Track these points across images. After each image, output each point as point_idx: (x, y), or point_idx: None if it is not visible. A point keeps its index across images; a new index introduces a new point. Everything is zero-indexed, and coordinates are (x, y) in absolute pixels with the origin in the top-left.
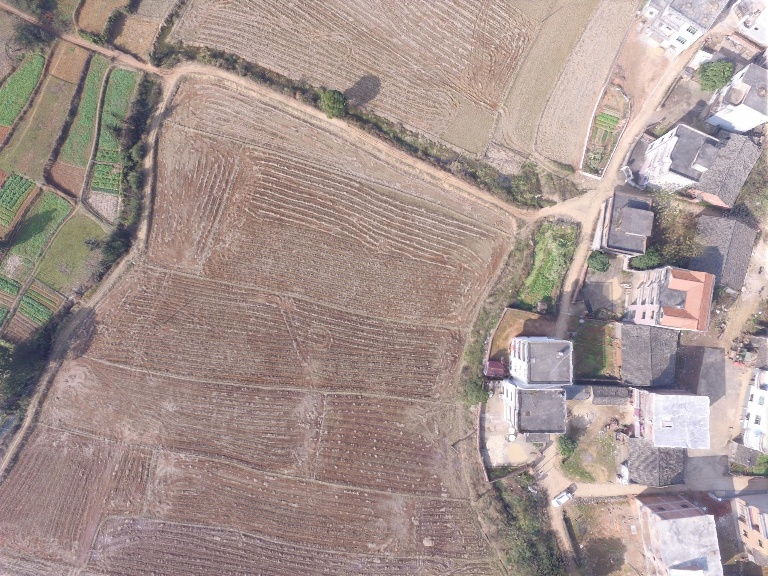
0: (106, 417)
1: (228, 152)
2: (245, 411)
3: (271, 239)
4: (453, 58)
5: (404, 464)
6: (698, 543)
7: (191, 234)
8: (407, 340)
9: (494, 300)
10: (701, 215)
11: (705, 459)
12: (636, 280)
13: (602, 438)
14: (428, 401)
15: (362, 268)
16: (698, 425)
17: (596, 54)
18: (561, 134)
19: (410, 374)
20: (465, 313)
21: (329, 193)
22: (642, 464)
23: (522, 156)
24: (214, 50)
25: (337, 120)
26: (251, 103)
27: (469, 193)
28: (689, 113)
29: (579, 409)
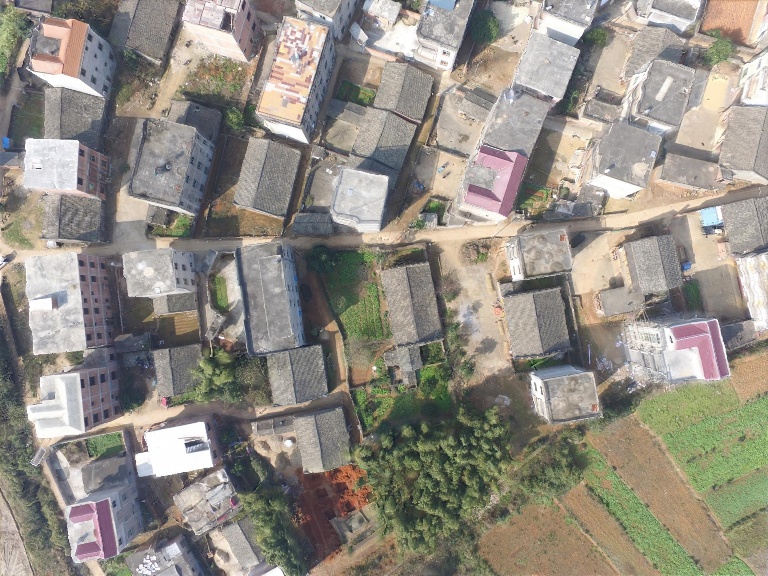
0: None
1: None
2: None
3: None
4: None
5: None
6: (60, 278)
7: None
8: None
9: None
10: None
11: (132, 224)
12: None
13: (41, 206)
14: None
15: None
16: (66, 167)
17: None
18: None
19: None
20: None
21: None
22: (50, 219)
23: None
24: None
25: None
26: None
27: None
28: None
29: (21, 179)
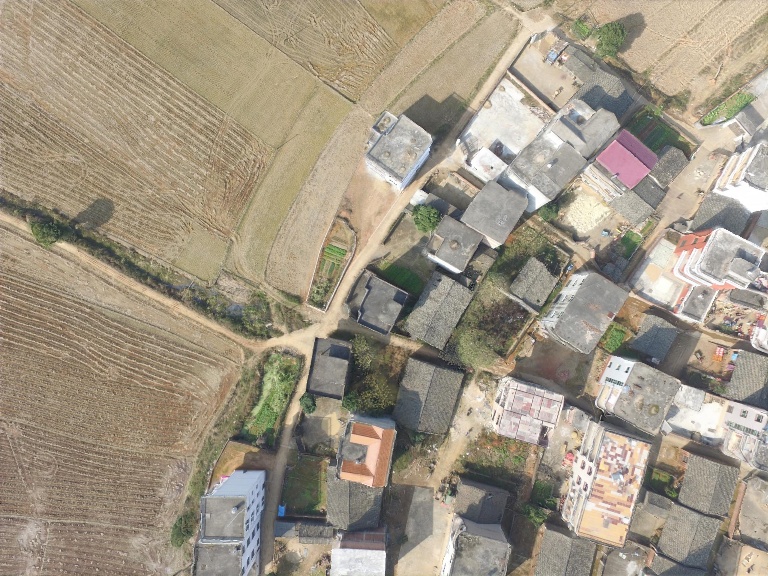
0: None
1: None
2: None
3: None
4: (188, 183)
5: None
6: None
7: None
8: (133, 468)
9: (218, 431)
10: (419, 353)
11: None
12: None
13: (314, 573)
14: (151, 530)
15: (90, 395)
16: None
17: (328, 184)
18: (291, 264)
19: (134, 503)
20: (191, 442)
21: (59, 318)
22: None
23: (252, 285)
24: None
25: (67, 245)
26: None
27: (197, 322)
28: (413, 248)
29: (293, 544)
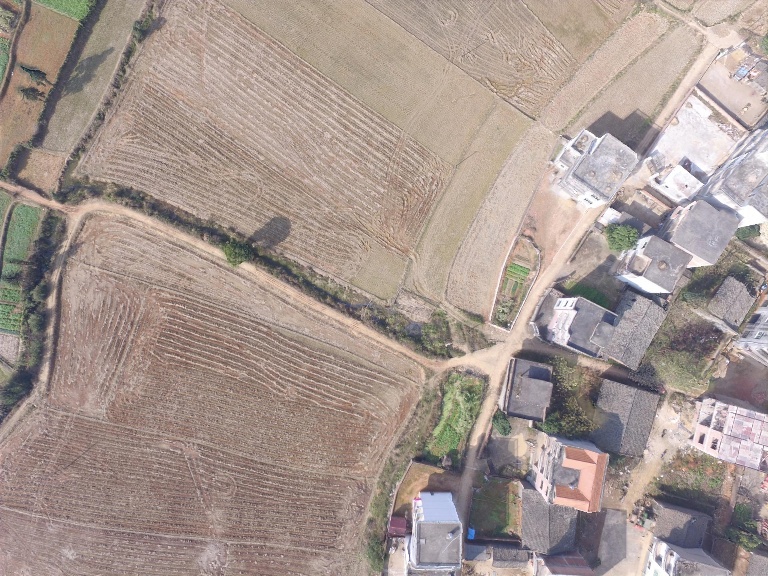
0: (4, 564)
1: (134, 292)
2: (147, 560)
3: (176, 383)
4: (365, 201)
5: None
6: None
7: (94, 377)
8: (312, 489)
9: (400, 452)
10: (608, 373)
11: None
12: (540, 439)
13: None
14: (332, 552)
15: (268, 415)
16: None
17: (509, 201)
18: (472, 283)
19: (315, 524)
20: (372, 463)
21: (236, 337)
22: None
23: (432, 304)
24: (121, 186)
25: (245, 263)
26: (158, 242)
27: (377, 341)
28: (599, 267)
29: (481, 567)
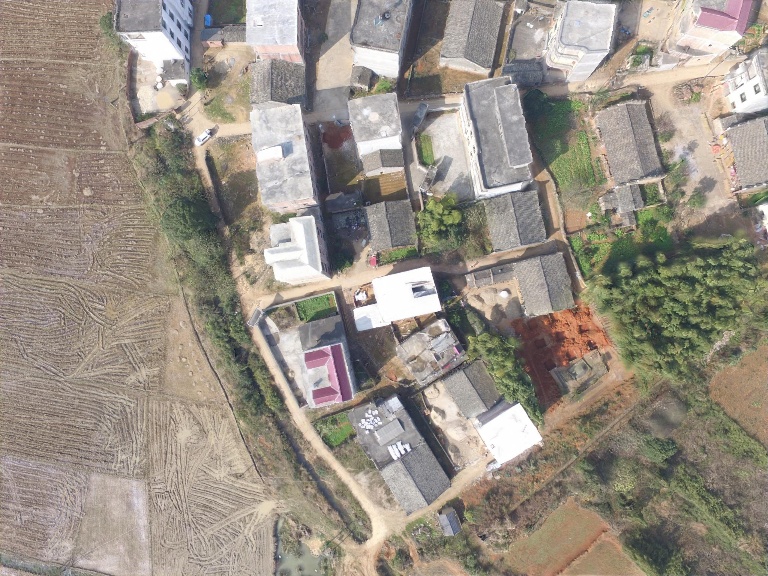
0: None
1: None
2: None
3: None
4: None
5: (66, 122)
6: (285, 129)
7: None
8: (70, 8)
9: None
10: None
11: (332, 91)
12: None
13: (241, 81)
14: (89, 63)
15: None
16: (286, 23)
17: None
18: None
19: (72, 39)
20: None
21: None
22: (260, 85)
23: None
24: None
25: None
26: None
27: None
28: None
29: (221, 56)
